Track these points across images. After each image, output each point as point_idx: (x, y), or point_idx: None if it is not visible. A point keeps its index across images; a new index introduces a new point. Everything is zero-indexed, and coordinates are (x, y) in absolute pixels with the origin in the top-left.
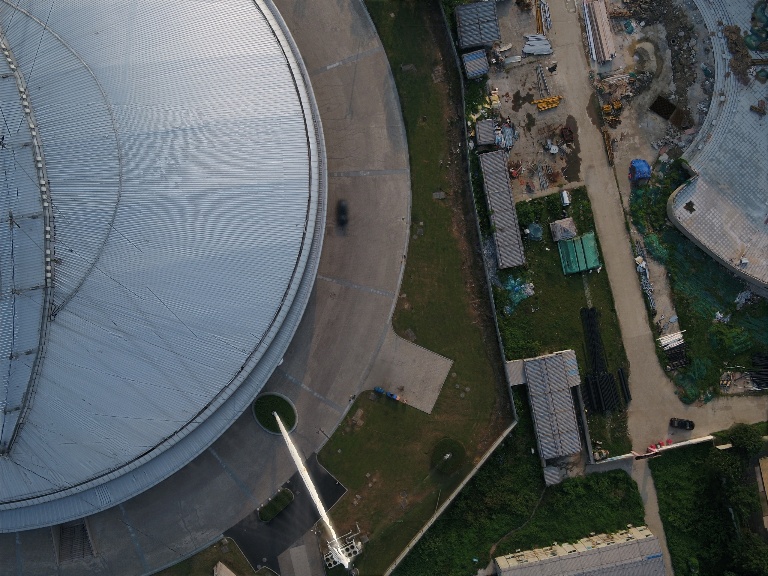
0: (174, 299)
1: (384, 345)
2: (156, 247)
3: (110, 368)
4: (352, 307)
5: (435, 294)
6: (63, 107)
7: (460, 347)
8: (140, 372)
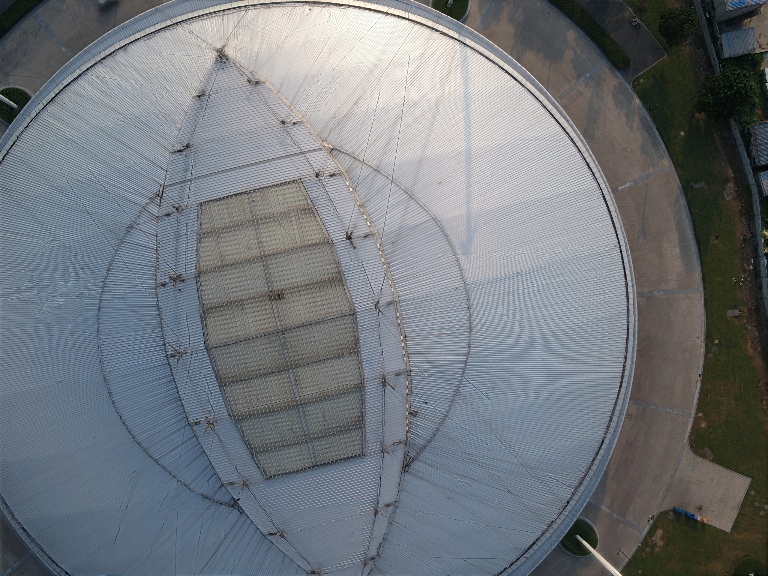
0: (515, 442)
1: (681, 464)
2: (501, 393)
3: (455, 513)
4: (649, 427)
5: (732, 412)
6: (416, 261)
7: (758, 465)
8: (481, 515)
